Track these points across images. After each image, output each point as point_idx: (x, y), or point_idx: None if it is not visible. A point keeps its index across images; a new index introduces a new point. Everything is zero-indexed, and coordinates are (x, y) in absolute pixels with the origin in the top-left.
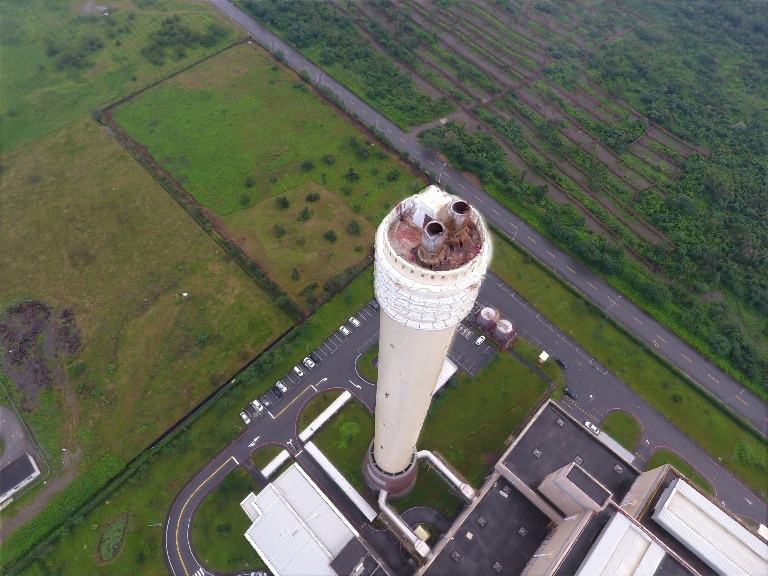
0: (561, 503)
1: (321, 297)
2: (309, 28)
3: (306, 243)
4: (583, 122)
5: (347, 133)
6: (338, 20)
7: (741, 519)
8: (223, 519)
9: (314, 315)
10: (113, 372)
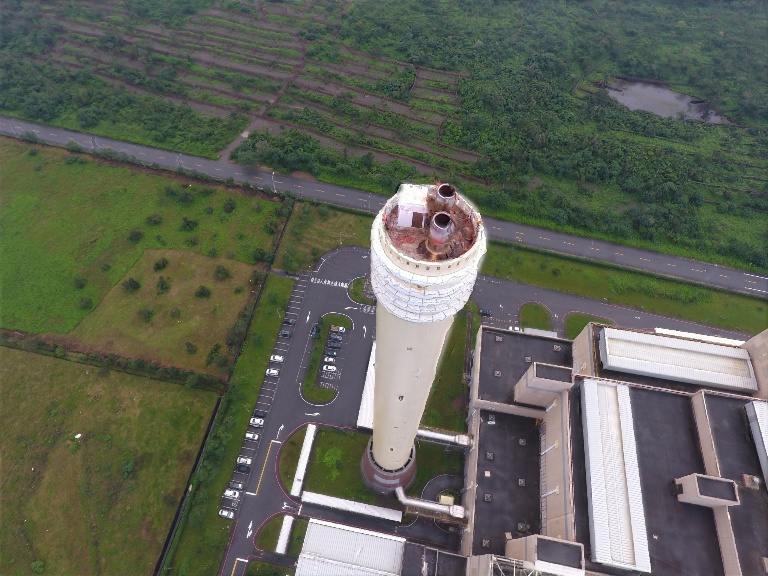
0: (538, 400)
1: (230, 354)
2: (48, 96)
3: (182, 312)
4: (365, 87)
5: (157, 186)
6: (75, 77)
7: None
8: None
9: (234, 375)
10: (43, 569)
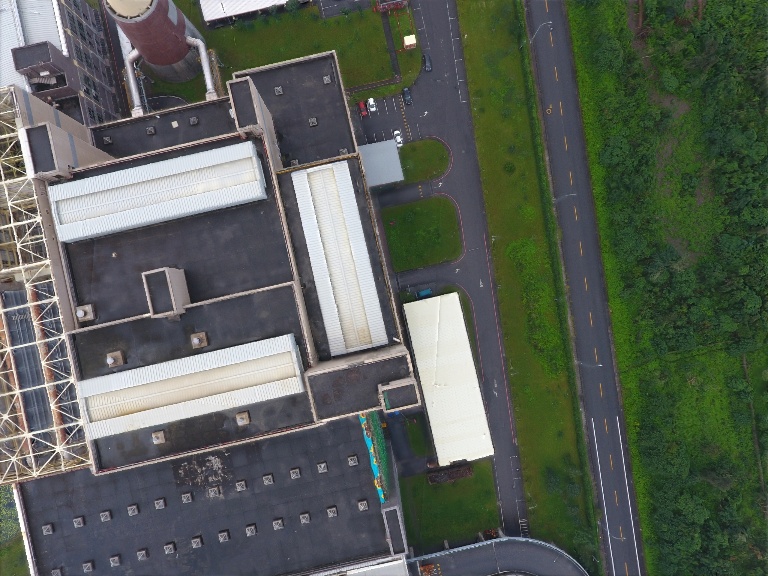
0: None
1: None
2: None
3: None
4: None
5: None
6: None
7: (459, 290)
8: None
9: None
10: None
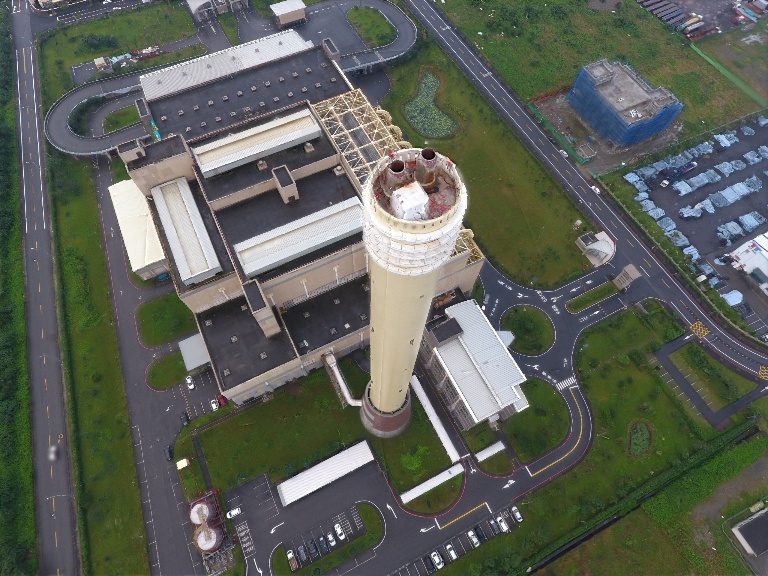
0: None
1: None
2: None
3: None
4: None
5: None
6: None
7: (138, 286)
8: (541, 421)
9: None
10: None
